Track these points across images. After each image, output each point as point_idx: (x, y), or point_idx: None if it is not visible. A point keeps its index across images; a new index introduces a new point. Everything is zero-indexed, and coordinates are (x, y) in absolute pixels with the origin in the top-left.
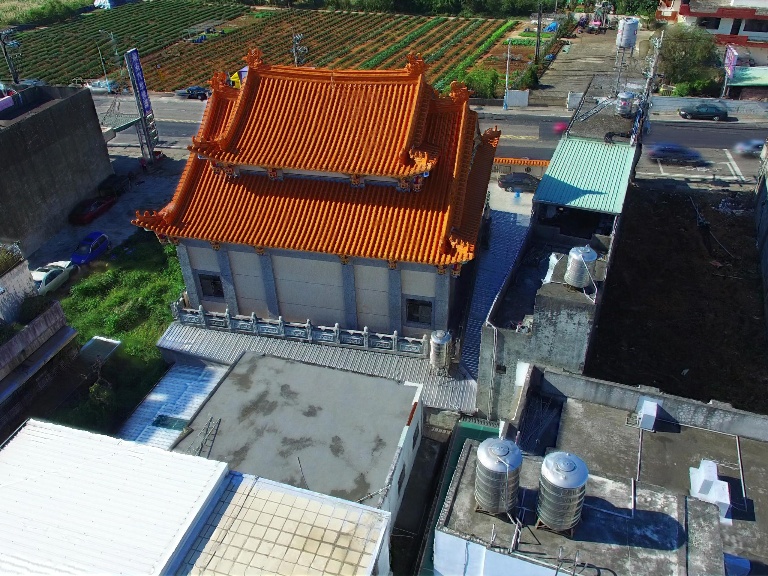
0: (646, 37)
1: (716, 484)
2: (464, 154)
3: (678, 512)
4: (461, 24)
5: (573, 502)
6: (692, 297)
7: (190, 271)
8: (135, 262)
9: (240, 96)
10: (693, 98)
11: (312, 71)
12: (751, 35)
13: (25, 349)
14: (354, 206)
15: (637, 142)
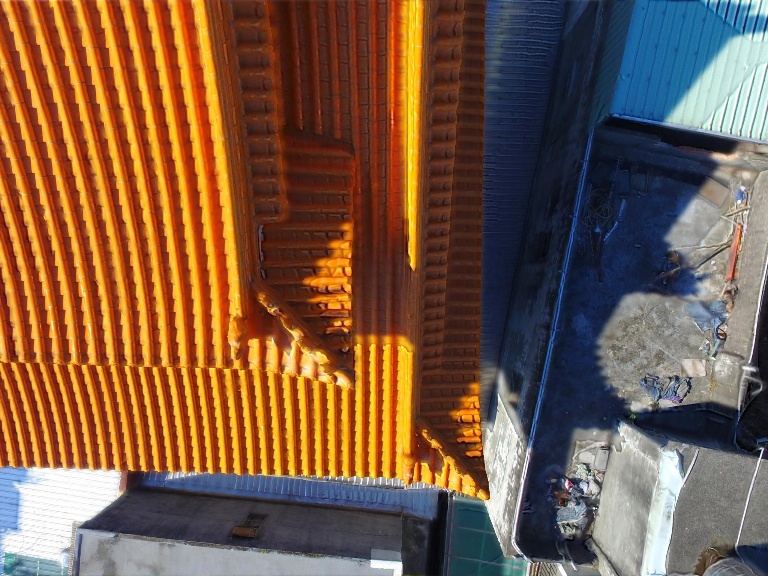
0: None
1: None
2: (431, 164)
3: None
4: None
5: None
6: None
7: None
8: None
9: None
10: None
11: None
12: None
13: None
14: None
15: None
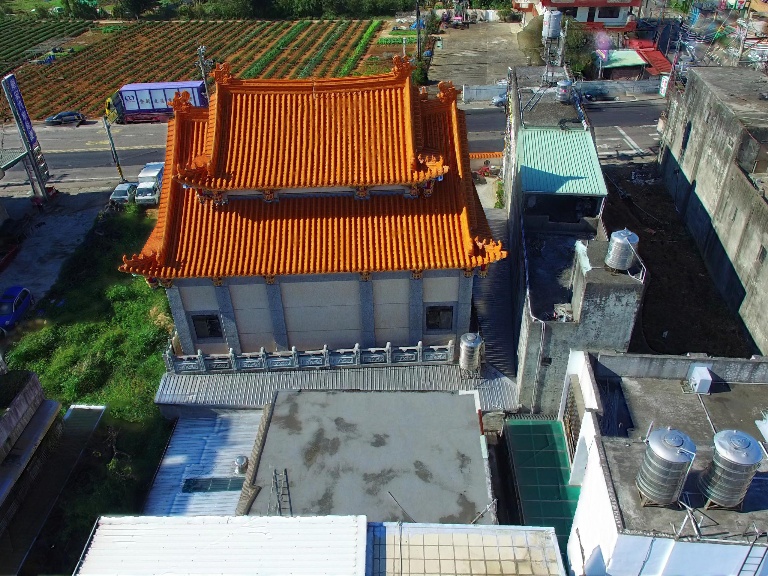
0: (507, 29)
1: None
2: (463, 154)
3: None
4: (328, 27)
5: (750, 476)
6: None
7: (183, 314)
8: (72, 314)
9: (211, 116)
10: (593, 82)
11: (290, 82)
12: (606, 21)
13: (10, 436)
14: (365, 219)
15: (590, 126)
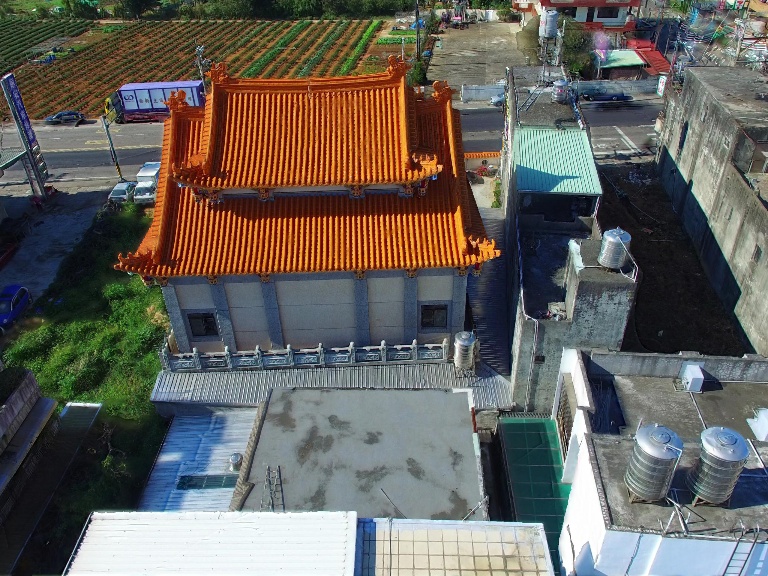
0: (506, 29)
1: None
2: (457, 153)
3: None
4: (328, 27)
5: (737, 473)
6: (639, 264)
7: (179, 312)
8: (69, 313)
9: (207, 115)
10: (591, 81)
11: (285, 82)
12: (605, 21)
13: (5, 433)
14: (359, 218)
15: (586, 126)
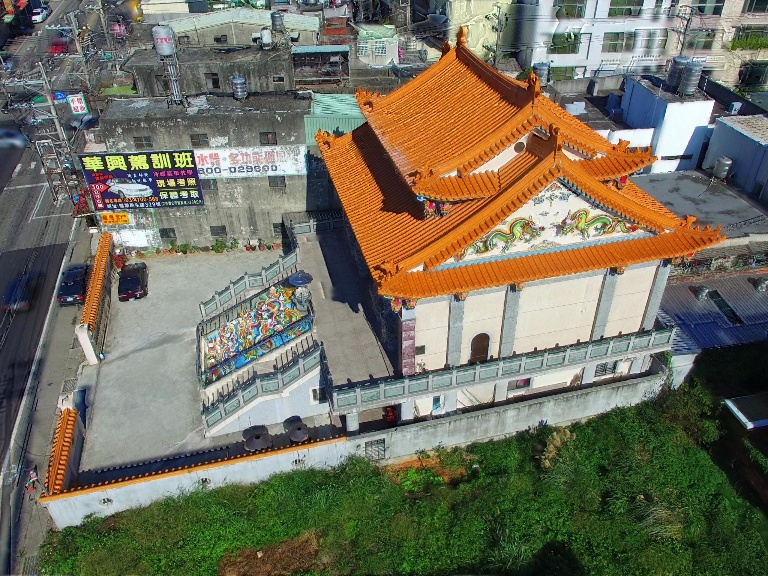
0: None
1: (577, 103)
2: None
3: (638, 76)
4: None
5: None
6: None
7: None
8: None
9: None
10: None
11: None
12: None
13: None
14: None
15: None
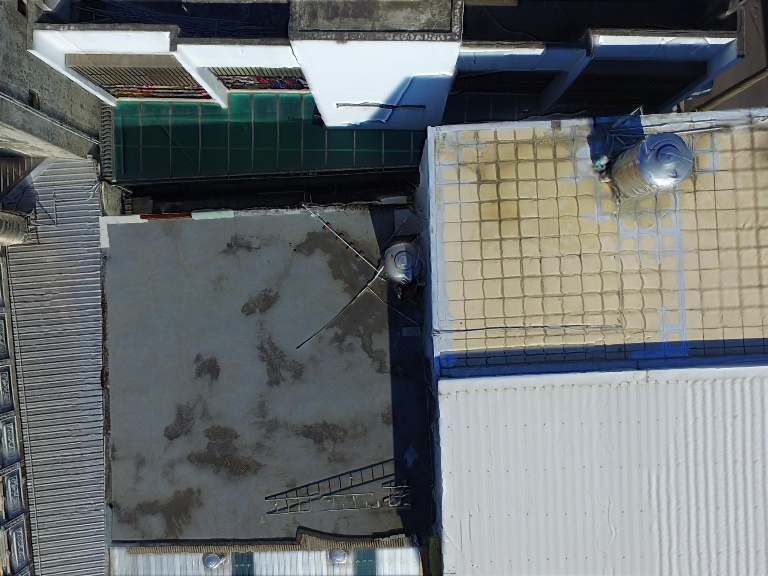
0: None
1: None
2: None
3: None
4: None
5: None
6: None
7: None
8: None
9: None
10: None
11: None
12: None
13: None
14: None
15: None
